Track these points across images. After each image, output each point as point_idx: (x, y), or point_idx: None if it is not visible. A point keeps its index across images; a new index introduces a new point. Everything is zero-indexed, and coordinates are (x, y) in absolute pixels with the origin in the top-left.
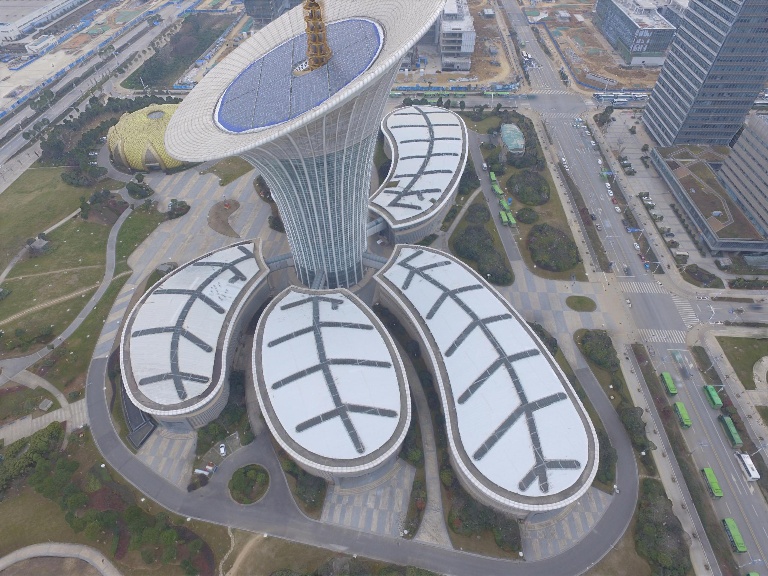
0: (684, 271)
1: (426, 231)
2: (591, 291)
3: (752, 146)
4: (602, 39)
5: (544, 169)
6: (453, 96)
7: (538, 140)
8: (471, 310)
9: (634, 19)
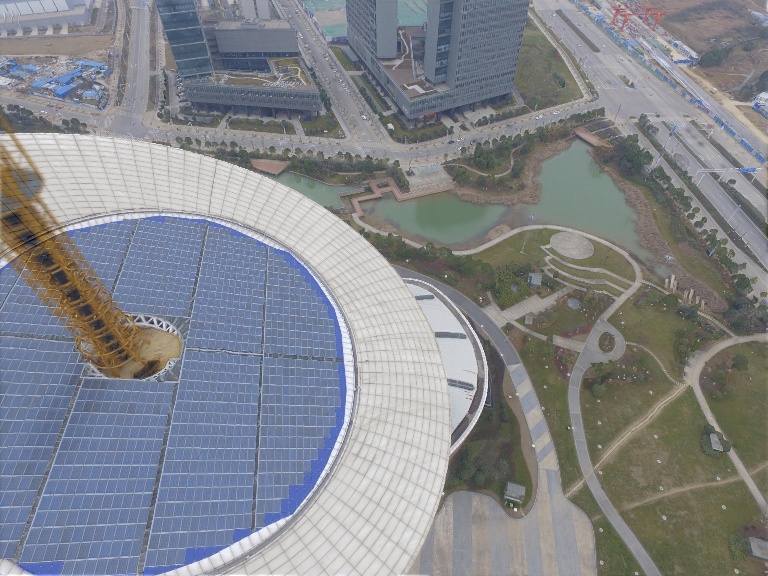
0: None
1: None
2: None
3: None
4: None
5: None
6: None
7: None
8: None
9: None
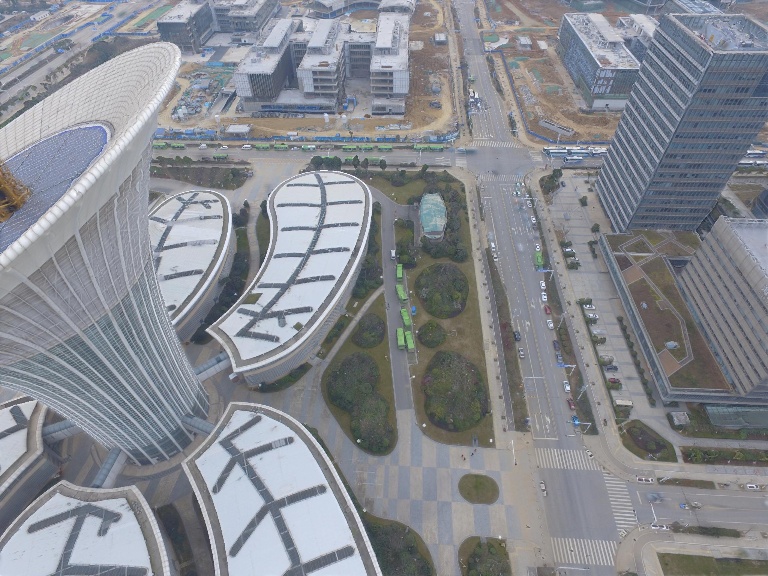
0: (625, 431)
1: (292, 363)
2: (496, 465)
3: (718, 259)
4: (564, 73)
5: (466, 259)
6: (377, 150)
7: (467, 214)
8: (293, 543)
9: (596, 55)
